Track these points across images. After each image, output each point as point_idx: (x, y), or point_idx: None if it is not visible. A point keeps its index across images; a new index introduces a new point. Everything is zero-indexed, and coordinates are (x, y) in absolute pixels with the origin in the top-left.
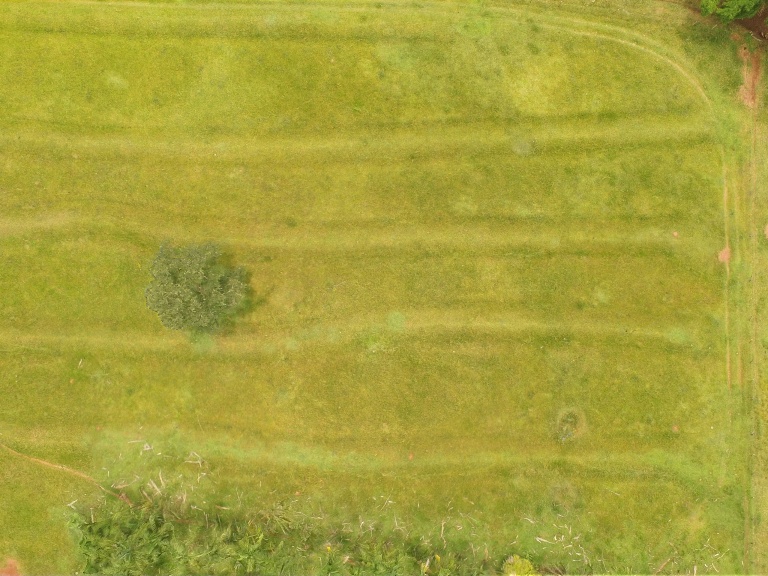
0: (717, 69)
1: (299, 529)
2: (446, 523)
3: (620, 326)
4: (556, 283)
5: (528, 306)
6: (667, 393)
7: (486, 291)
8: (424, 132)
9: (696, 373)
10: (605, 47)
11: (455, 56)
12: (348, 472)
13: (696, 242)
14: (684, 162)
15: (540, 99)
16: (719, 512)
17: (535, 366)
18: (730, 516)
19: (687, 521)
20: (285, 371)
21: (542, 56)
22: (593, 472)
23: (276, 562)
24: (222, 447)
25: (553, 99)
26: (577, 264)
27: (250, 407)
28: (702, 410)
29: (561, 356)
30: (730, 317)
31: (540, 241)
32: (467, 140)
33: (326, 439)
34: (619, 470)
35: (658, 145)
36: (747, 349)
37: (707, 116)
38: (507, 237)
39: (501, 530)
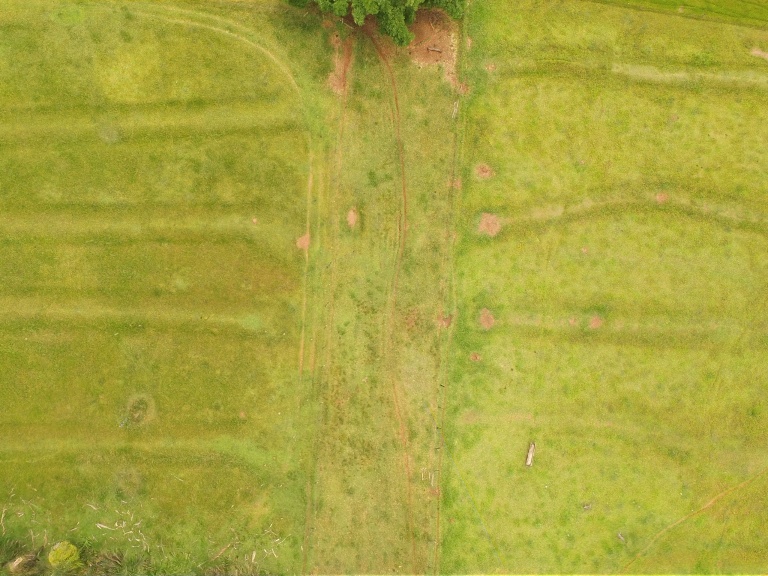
0: (308, 56)
1: None
2: (7, 510)
3: (195, 313)
4: (135, 270)
5: (105, 293)
6: (236, 379)
7: (64, 278)
8: (12, 120)
9: (267, 359)
10: (197, 35)
11: (47, 44)
12: None
13: (275, 229)
14: (269, 149)
15: (130, 87)
16: (284, 497)
17: (108, 353)
18: (294, 501)
19: (251, 507)
20: None
21: (134, 44)
22: (160, 458)
23: None
24: None
25: (143, 87)
26: (157, 251)
27: None
28: (270, 396)
29: (134, 343)
30: (307, 303)
31: (120, 228)
32: (53, 128)
33: None
34: (186, 456)
35: (245, 132)
36: (321, 335)
37: (295, 103)
38: (88, 224)
39: (62, 517)
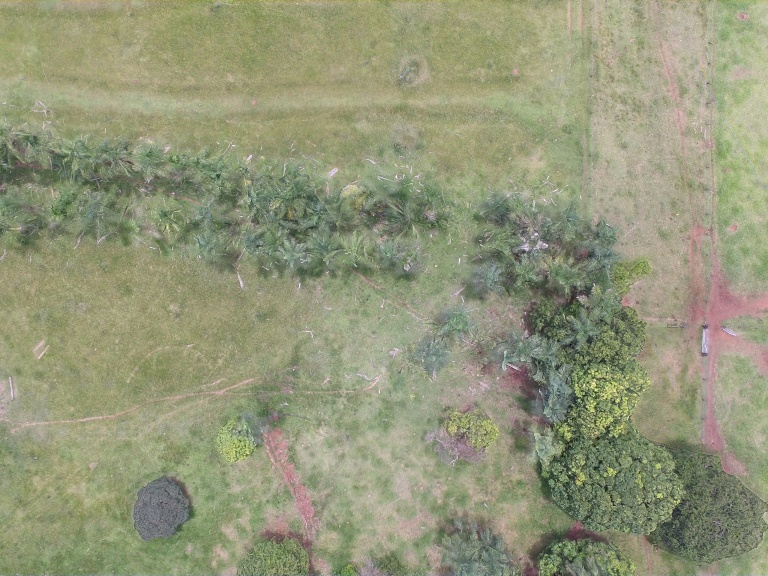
0: None
1: (142, 171)
2: (288, 164)
3: None
4: None
5: None
6: (507, 39)
7: None
8: None
9: (536, 19)
10: None
11: None
12: (192, 118)
13: None
14: None
15: None
16: (559, 151)
17: (378, 17)
18: (569, 155)
19: (527, 160)
20: (130, 25)
21: None
22: (435, 116)
23: (120, 203)
24: (67, 96)
25: None
26: None
27: (96, 60)
28: (542, 54)
29: (403, 7)
30: None
31: None
32: None
33: (171, 89)
34: (460, 113)
35: None
36: None
37: None
38: None
39: (343, 170)
